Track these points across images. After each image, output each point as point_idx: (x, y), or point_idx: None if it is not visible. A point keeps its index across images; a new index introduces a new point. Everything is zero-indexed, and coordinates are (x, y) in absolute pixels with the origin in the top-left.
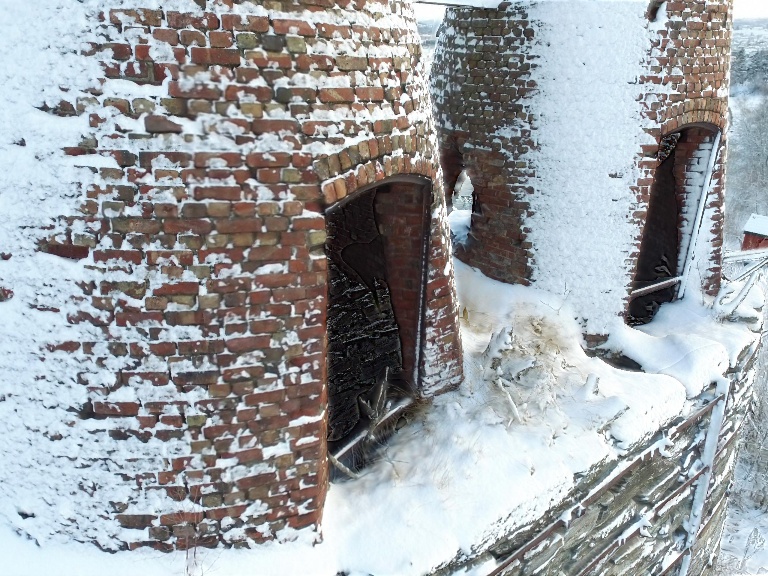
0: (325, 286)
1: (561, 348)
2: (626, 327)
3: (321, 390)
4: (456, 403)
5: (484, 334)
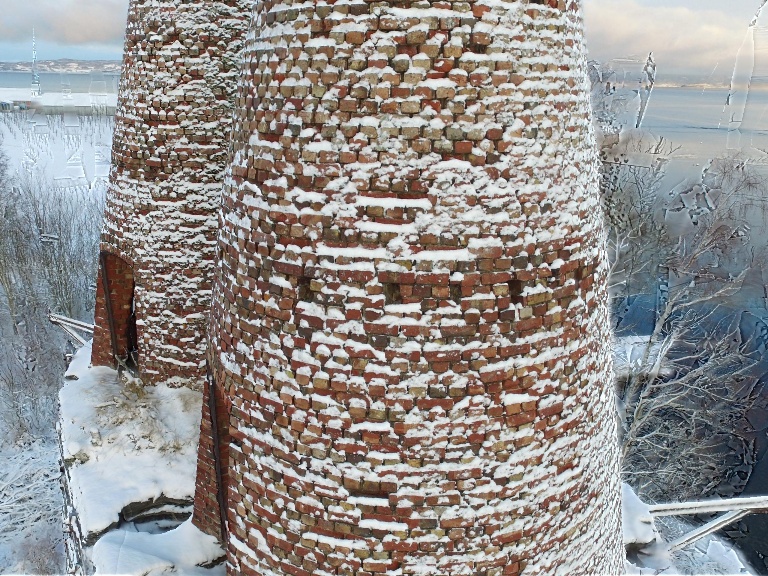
0: (99, 279)
1: (173, 459)
2: (206, 535)
3: (97, 316)
4: (129, 393)
5: (183, 404)
